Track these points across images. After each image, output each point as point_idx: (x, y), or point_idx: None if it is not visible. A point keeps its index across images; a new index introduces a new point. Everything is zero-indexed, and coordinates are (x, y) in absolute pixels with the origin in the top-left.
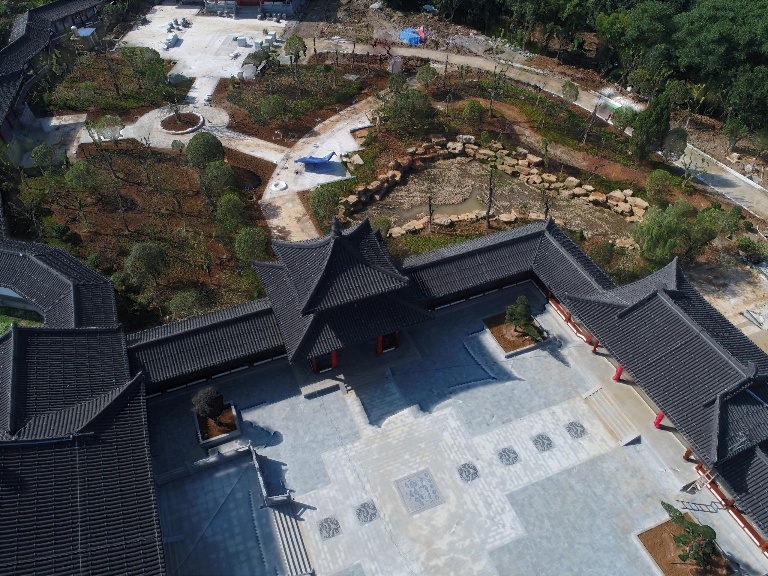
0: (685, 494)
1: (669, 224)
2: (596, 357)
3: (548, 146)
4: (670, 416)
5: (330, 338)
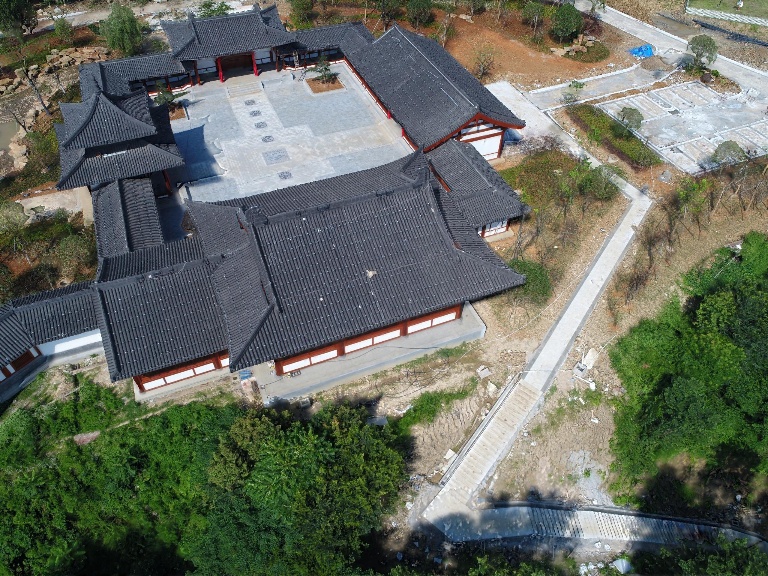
0: (295, 79)
1: (128, 17)
2: (204, 85)
3: None
4: (267, 46)
5: (167, 147)
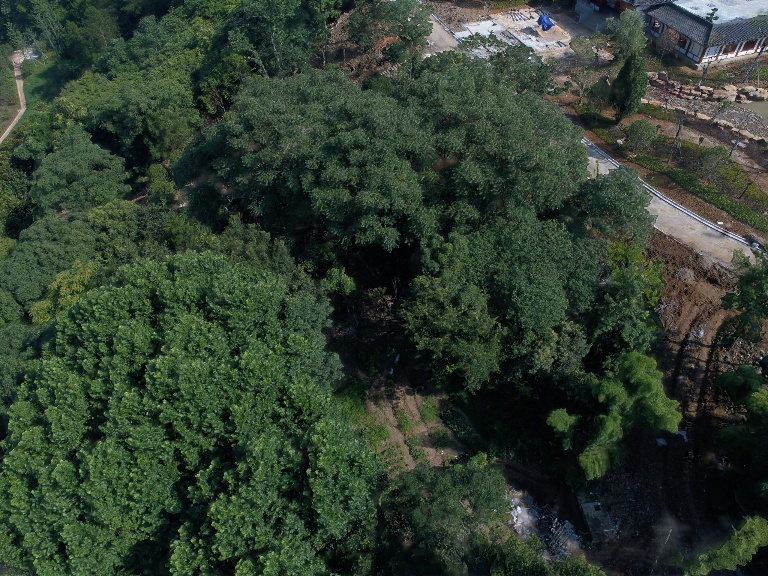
0: None
1: None
2: None
3: (713, 144)
4: None
5: None
